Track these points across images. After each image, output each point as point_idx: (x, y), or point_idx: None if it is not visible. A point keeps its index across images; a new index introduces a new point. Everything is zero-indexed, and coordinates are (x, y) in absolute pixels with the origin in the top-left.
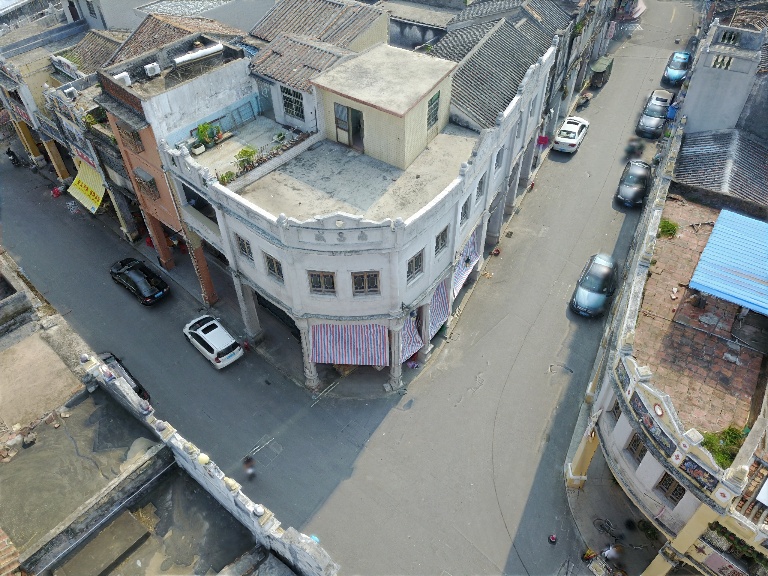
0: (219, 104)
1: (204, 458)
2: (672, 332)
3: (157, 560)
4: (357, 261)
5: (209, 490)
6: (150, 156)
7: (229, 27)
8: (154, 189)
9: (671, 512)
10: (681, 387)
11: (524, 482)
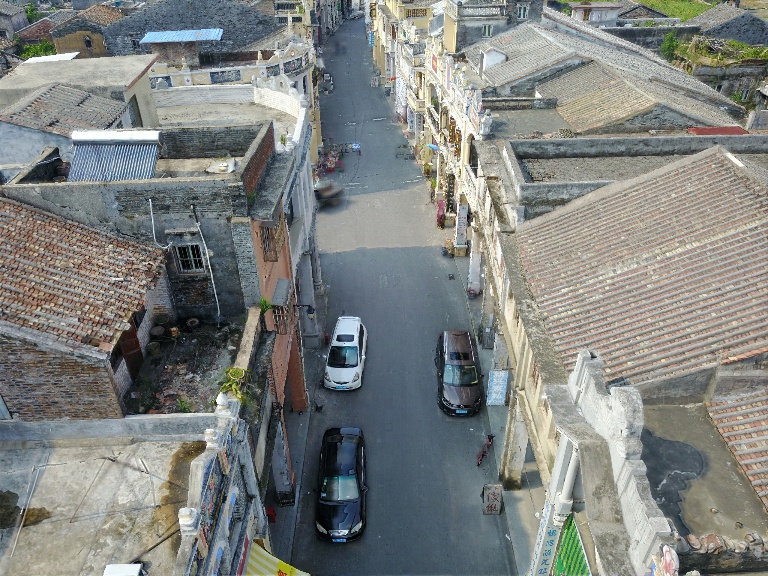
0: None
1: None
2: None
3: None
4: None
5: None
6: None
7: None
8: None
9: None
10: None
11: None
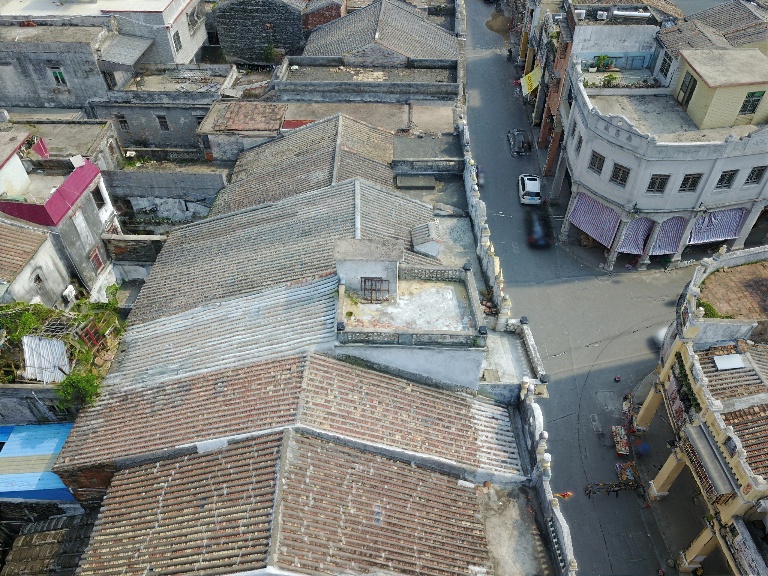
0: (623, 48)
1: (472, 161)
2: (767, 279)
3: (430, 197)
4: (621, 156)
5: (466, 190)
6: (565, 63)
7: (679, 12)
8: (557, 85)
9: (669, 350)
10: (733, 294)
11: (631, 351)
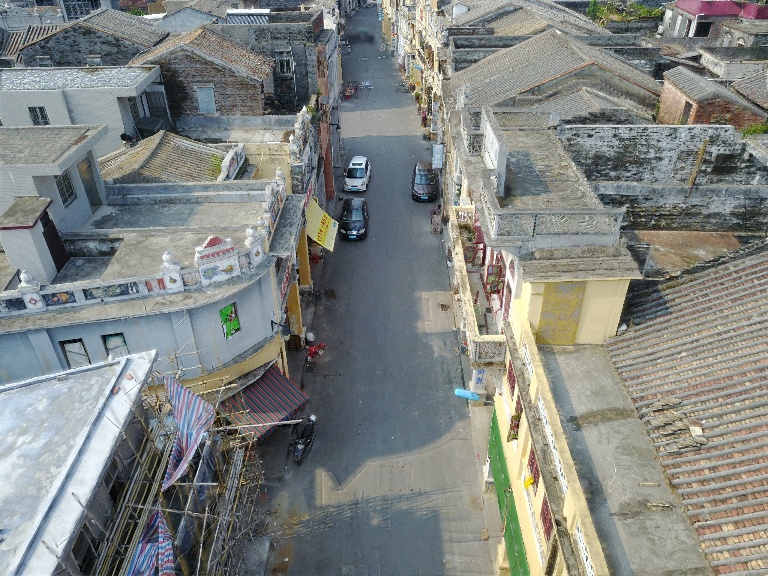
0: None
1: None
2: None
3: None
4: None
5: None
6: None
7: None
8: None
9: None
10: None
11: None
